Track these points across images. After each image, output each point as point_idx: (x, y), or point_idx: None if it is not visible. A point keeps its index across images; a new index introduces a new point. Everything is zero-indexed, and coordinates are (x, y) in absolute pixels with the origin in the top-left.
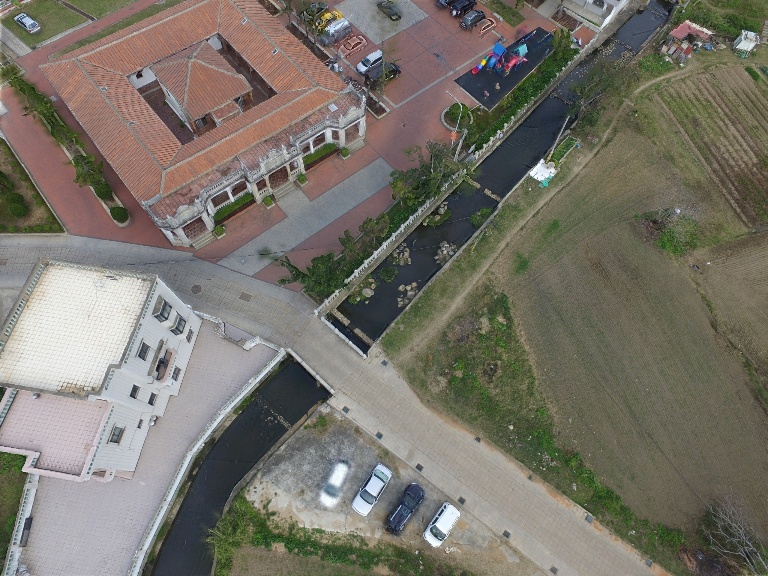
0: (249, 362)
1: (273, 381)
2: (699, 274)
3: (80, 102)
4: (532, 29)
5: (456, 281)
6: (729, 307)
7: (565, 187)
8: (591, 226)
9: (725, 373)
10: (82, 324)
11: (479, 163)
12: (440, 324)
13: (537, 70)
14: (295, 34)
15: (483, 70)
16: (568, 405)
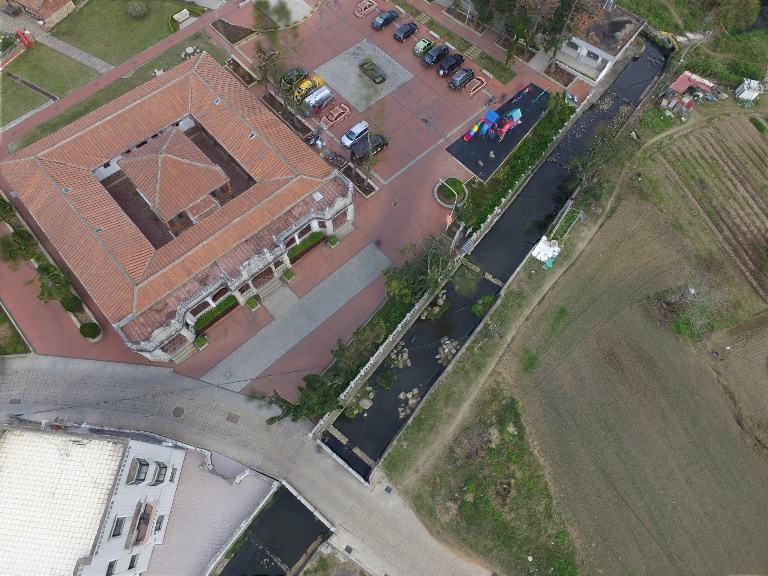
0: (240, 497)
1: (267, 515)
2: (719, 361)
3: (42, 206)
4: (524, 86)
5: (460, 386)
6: (753, 398)
7: (570, 267)
8: (601, 311)
9: (755, 477)
10: (46, 505)
11: (477, 243)
12: (446, 438)
13: (532, 133)
14: (273, 105)
15: (475, 136)
16: (590, 527)
